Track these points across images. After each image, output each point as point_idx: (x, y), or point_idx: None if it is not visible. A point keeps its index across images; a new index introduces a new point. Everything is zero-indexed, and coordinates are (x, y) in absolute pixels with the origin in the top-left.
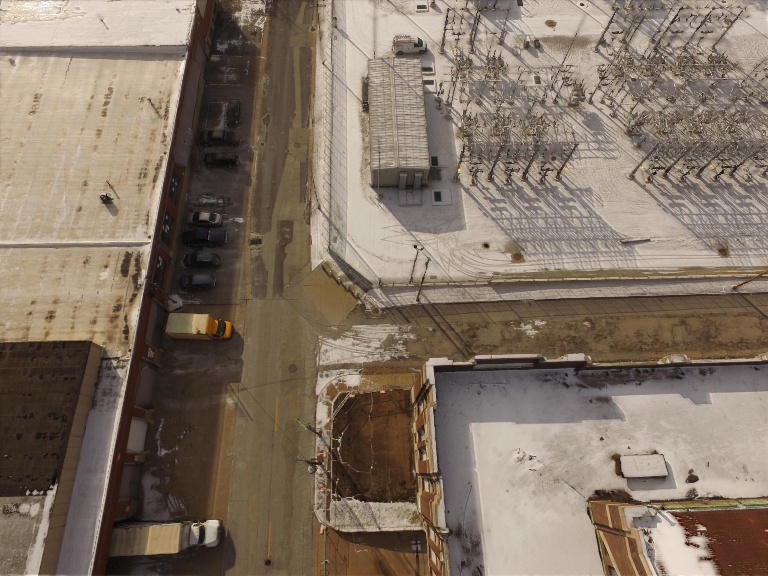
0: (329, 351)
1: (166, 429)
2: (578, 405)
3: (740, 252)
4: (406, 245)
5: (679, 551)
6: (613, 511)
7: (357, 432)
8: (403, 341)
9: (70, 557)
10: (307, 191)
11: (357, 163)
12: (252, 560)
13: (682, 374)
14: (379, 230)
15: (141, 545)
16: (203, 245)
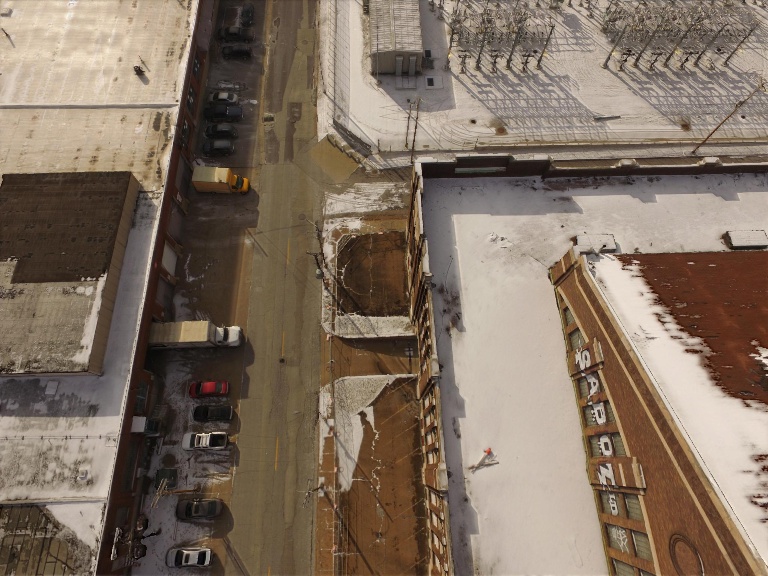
0: (334, 203)
1: (193, 262)
2: (543, 203)
3: (701, 127)
4: (402, 121)
5: (616, 272)
6: (566, 257)
7: (358, 264)
8: (399, 194)
9: (118, 335)
10: (314, 79)
11: (358, 56)
12: (268, 359)
13: (633, 181)
14: (378, 109)
15: (175, 335)
16: (222, 120)
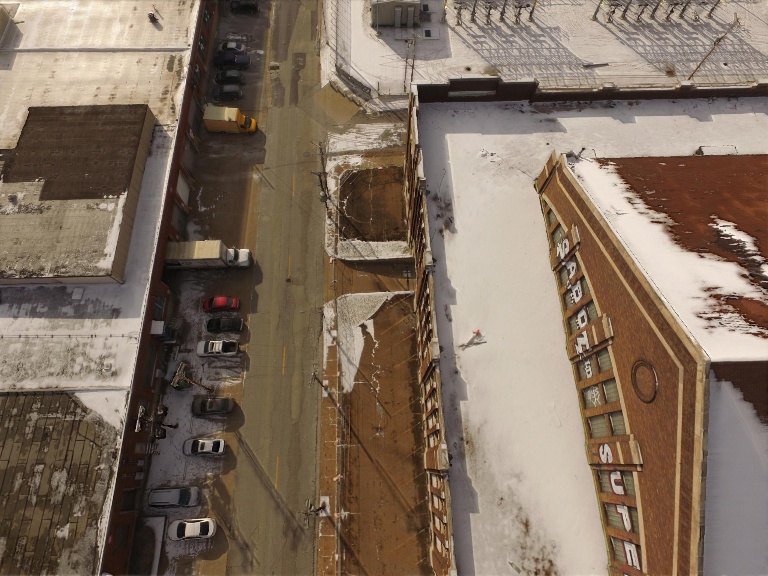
0: (336, 142)
1: (205, 194)
2: (530, 123)
3: (685, 73)
4: (401, 68)
5: (593, 170)
6: (549, 162)
7: (359, 196)
8: (397, 134)
9: (137, 249)
10: (317, 32)
11: (359, 10)
12: (276, 279)
13: (614, 105)
14: (378, 58)
15: (190, 252)
16: (231, 68)
